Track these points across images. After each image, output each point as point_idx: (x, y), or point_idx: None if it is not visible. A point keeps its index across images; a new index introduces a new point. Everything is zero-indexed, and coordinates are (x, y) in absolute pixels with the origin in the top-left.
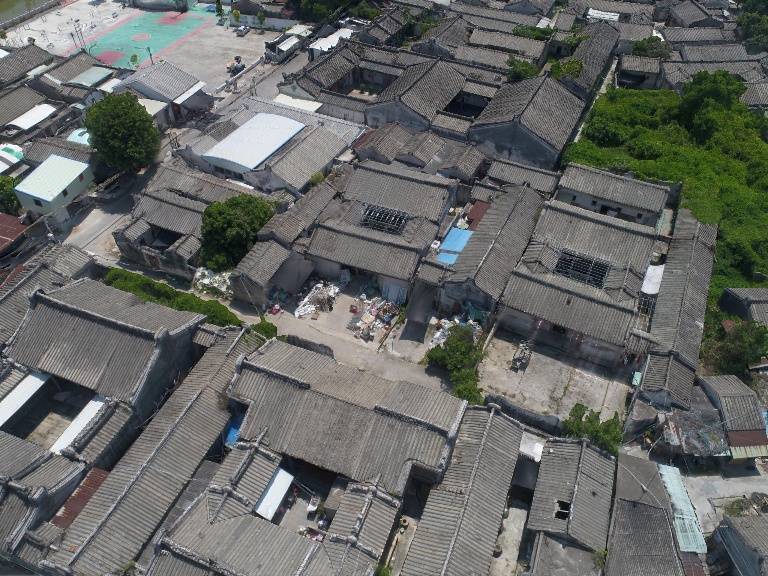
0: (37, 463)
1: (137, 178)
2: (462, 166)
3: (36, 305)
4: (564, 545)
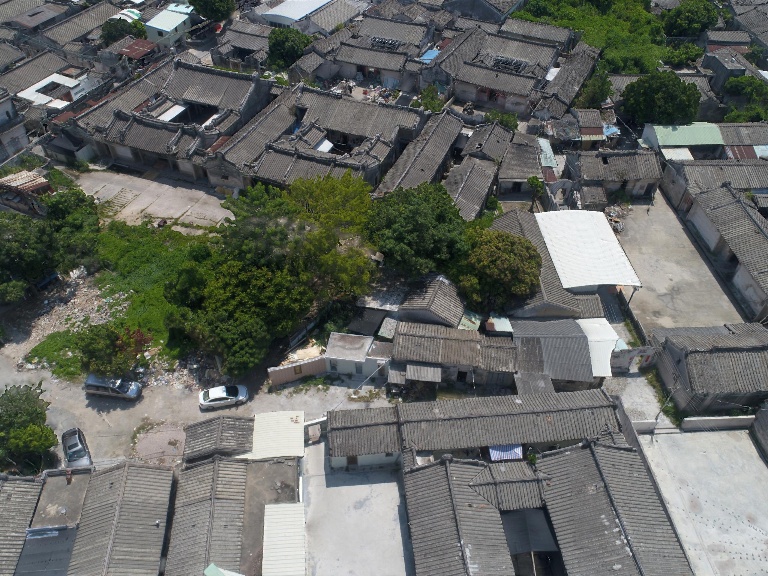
0: None
1: (215, 35)
2: (437, 20)
3: (178, 68)
4: (479, 159)
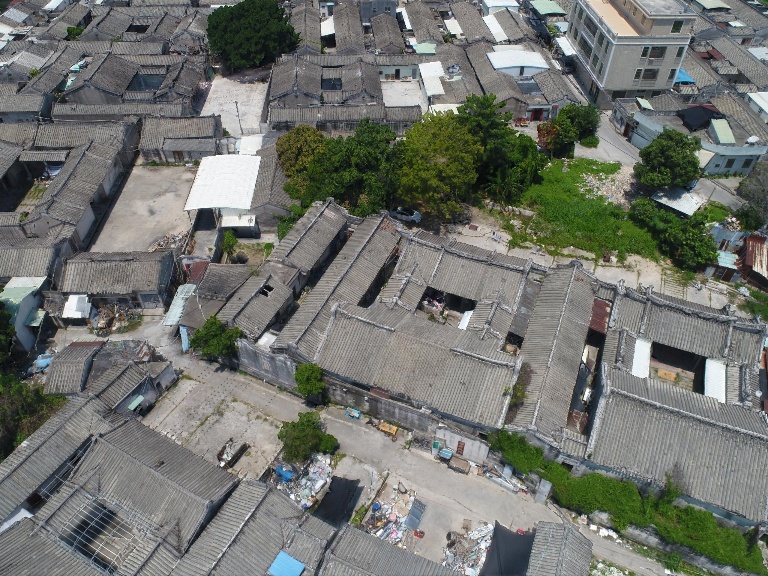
0: None
1: None
2: None
3: None
4: None
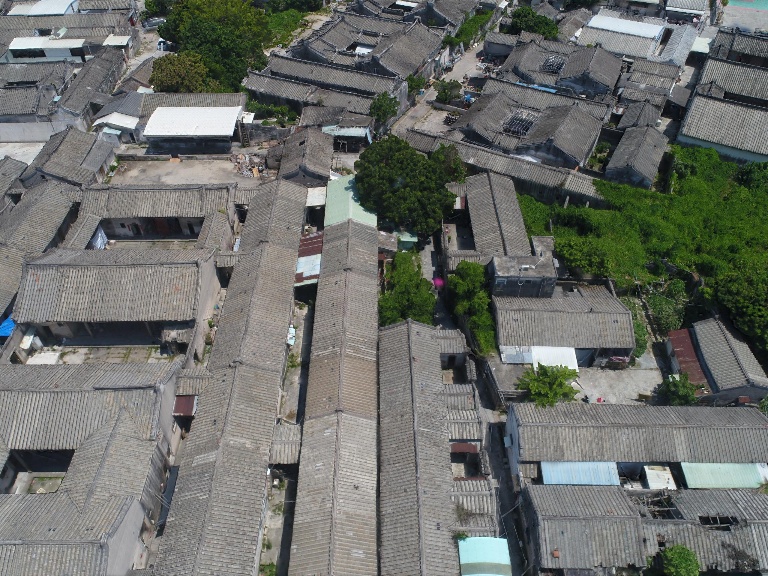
0: (377, 4)
1: None
2: (632, 91)
3: None
4: None
